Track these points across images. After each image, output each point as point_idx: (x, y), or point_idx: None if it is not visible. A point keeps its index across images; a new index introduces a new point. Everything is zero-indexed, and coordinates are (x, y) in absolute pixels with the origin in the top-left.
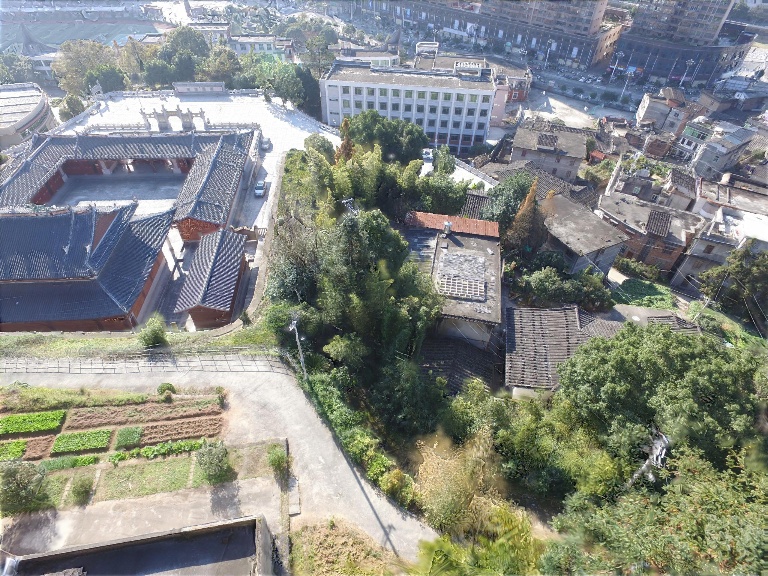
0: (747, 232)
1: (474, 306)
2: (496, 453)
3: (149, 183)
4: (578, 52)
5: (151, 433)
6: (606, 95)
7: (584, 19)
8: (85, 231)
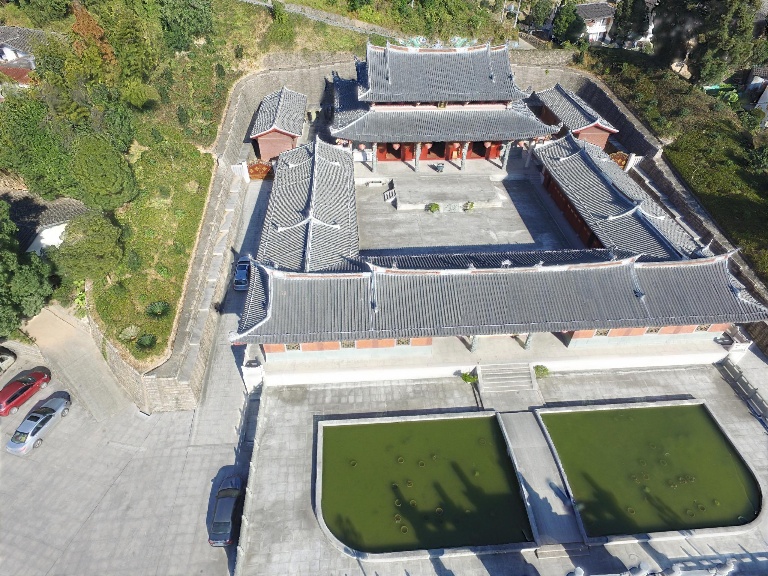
0: None
1: None
2: None
3: None
4: None
5: None
6: None
7: None
8: None
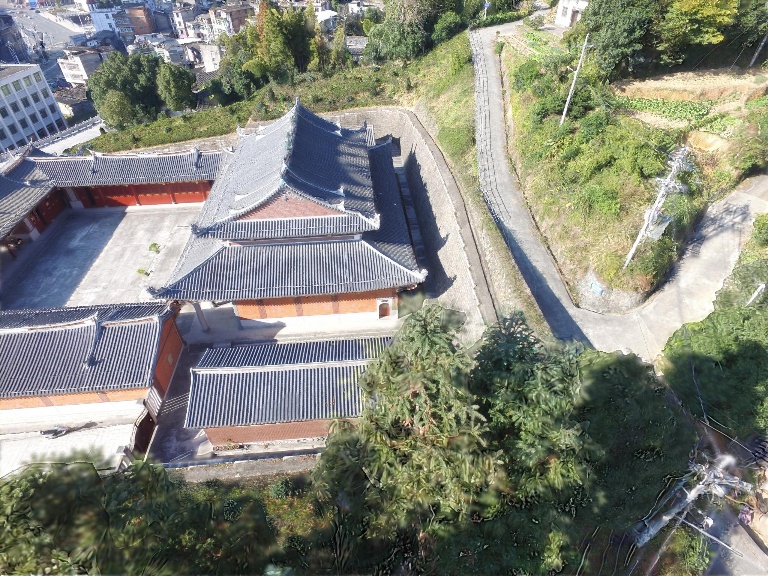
0: (321, 19)
1: None
2: (501, 8)
3: (46, 260)
4: None
5: None
6: None
7: None
8: (316, 120)
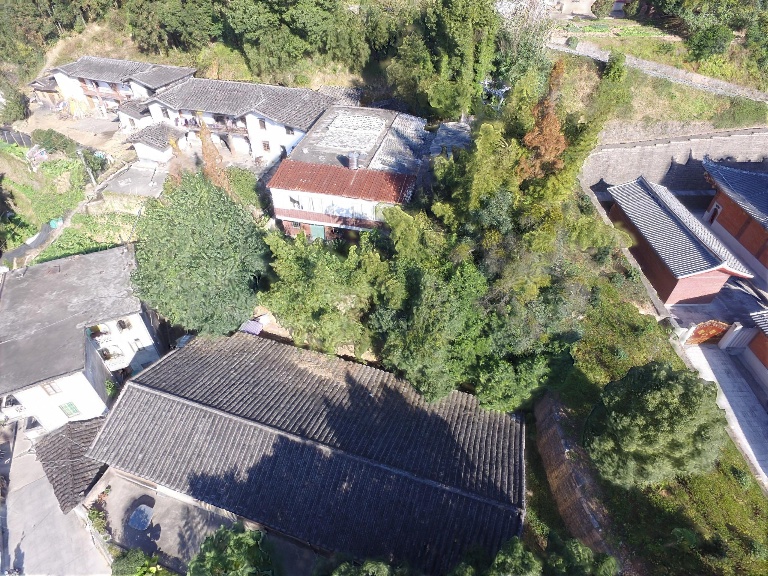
0: None
1: (350, 113)
2: None
3: None
4: None
5: (563, 31)
6: None
7: None
8: None
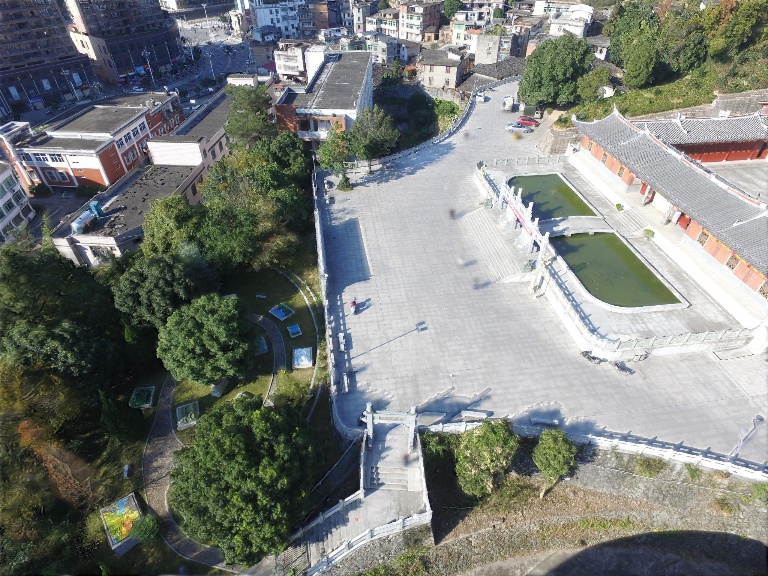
0: (590, 12)
1: None
2: None
3: None
4: (80, 77)
5: None
6: (209, 82)
7: (59, 38)
8: None
